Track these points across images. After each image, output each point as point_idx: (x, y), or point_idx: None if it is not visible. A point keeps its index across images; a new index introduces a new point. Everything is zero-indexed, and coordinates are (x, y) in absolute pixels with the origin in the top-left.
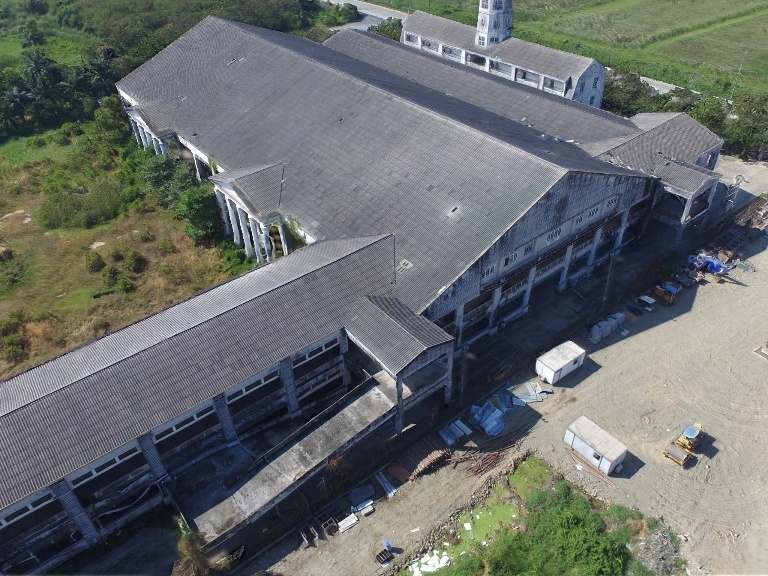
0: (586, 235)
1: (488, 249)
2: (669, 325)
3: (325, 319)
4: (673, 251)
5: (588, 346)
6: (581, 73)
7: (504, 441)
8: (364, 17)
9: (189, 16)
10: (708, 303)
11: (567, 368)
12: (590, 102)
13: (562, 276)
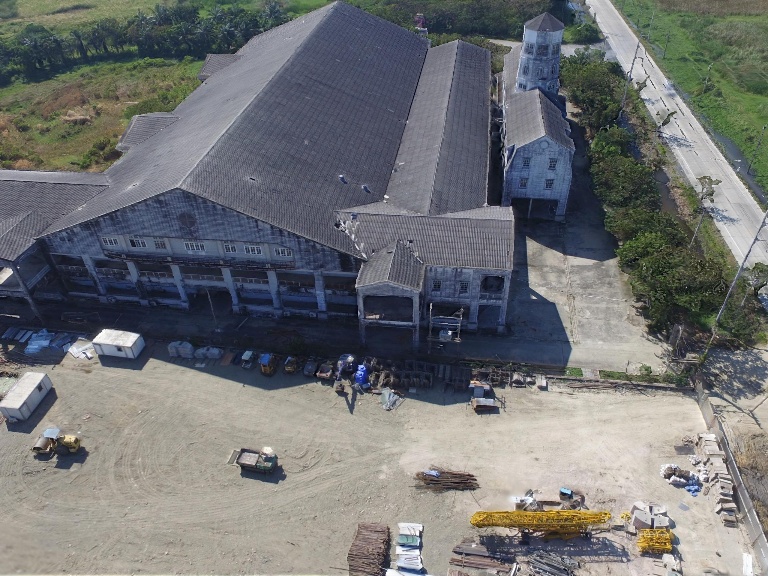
0: (243, 268)
1: (94, 218)
2: (233, 385)
3: (3, 211)
4: (360, 345)
5: (165, 353)
6: (522, 144)
7: (20, 359)
8: (598, 42)
9: (421, 2)
10: (292, 396)
11: (110, 349)
12: (547, 185)
13: (232, 298)
